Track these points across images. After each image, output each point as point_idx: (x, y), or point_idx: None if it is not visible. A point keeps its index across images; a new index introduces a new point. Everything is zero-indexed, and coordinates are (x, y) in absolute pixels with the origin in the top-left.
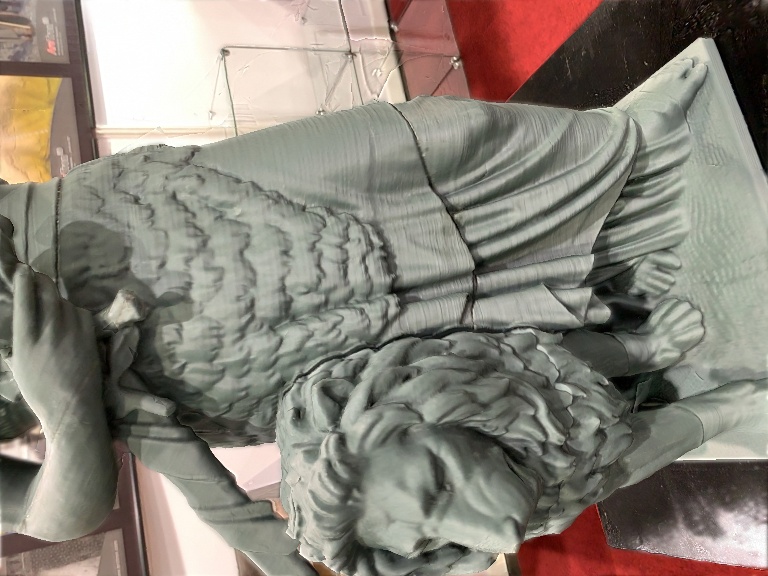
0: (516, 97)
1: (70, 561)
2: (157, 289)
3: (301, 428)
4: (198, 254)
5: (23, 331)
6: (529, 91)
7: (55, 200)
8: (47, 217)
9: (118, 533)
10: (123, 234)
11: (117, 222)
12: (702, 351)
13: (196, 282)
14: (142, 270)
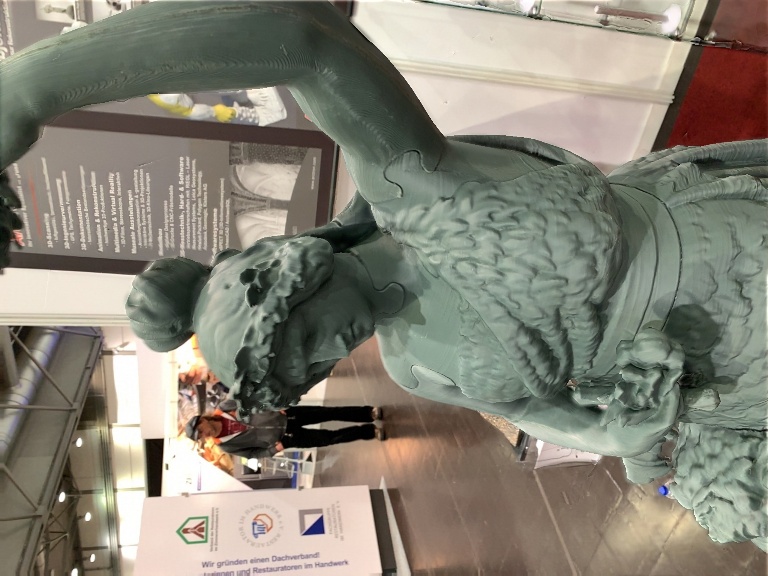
0: None
1: (277, 161)
2: (719, 371)
3: (751, 476)
4: (765, 356)
5: (658, 430)
6: None
7: (679, 273)
8: (669, 291)
9: (318, 152)
10: (721, 327)
11: (721, 314)
12: None
13: (749, 374)
14: (719, 358)
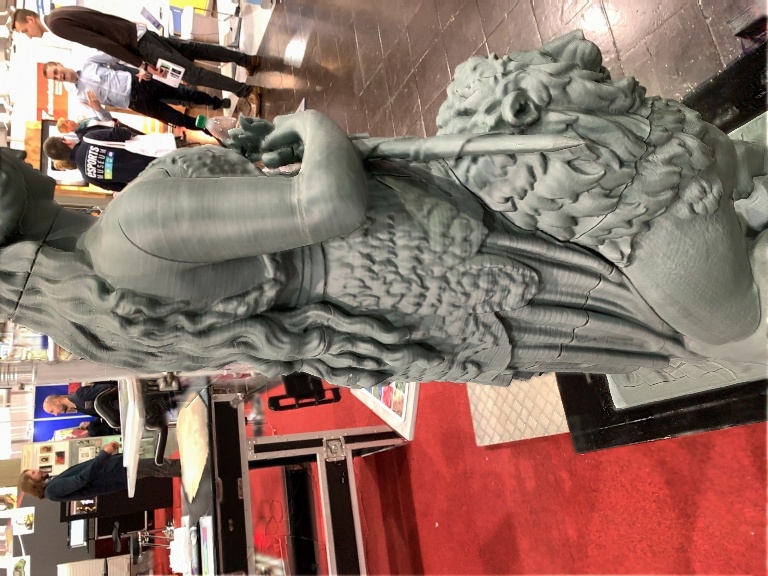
0: (567, 410)
1: None
2: None
3: None
4: None
5: None
6: (566, 392)
7: None
8: None
9: None
10: None
11: None
12: (736, 202)
13: None
14: None
